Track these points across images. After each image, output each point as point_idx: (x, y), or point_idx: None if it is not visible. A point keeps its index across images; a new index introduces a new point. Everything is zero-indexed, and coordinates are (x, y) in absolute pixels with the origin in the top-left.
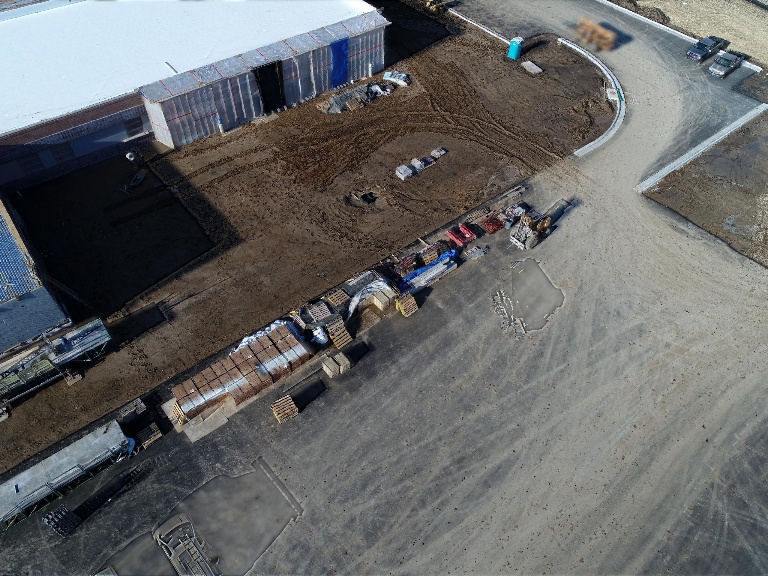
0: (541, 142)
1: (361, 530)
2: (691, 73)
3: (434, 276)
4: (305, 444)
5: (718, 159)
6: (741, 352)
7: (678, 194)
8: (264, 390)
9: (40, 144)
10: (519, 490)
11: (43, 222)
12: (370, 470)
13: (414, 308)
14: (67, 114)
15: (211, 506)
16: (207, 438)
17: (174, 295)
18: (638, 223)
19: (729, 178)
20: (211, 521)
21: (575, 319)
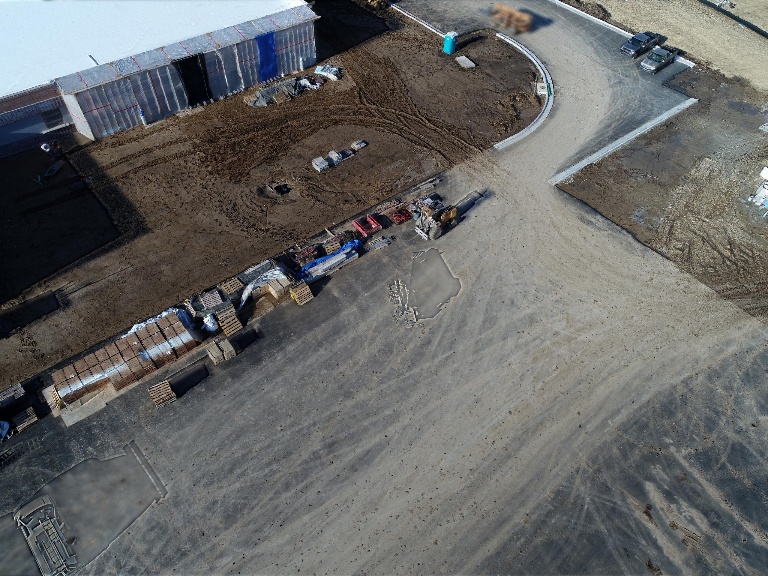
0: (463, 135)
1: (221, 512)
2: (624, 68)
3: (332, 265)
4: (179, 428)
5: (637, 152)
6: (628, 341)
7: (591, 186)
8: (147, 376)
9: None
10: (385, 474)
11: None
12: (240, 454)
13: (309, 297)
14: None
15: (76, 488)
16: (83, 422)
17: (72, 283)
18: (547, 215)
19: (645, 171)
20: (74, 503)
21: (468, 308)
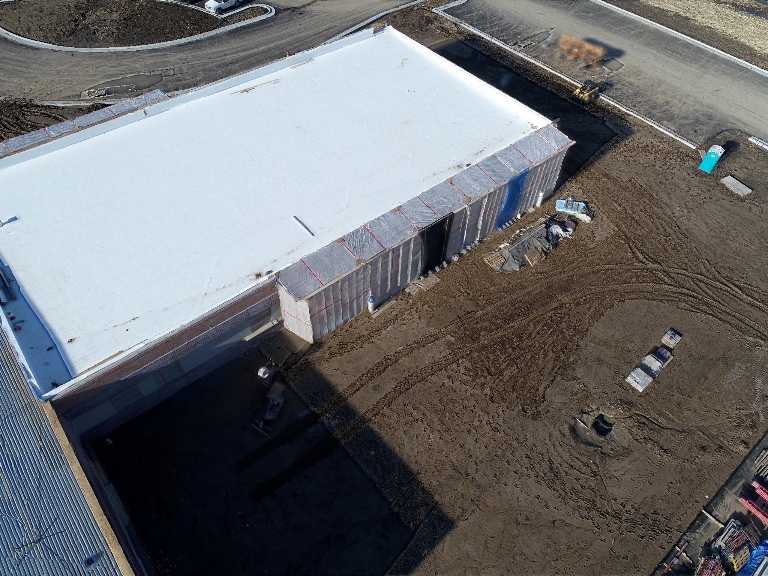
0: None
1: None
2: None
3: None
4: None
5: None
6: None
7: None
8: None
9: (141, 373)
10: None
11: (151, 496)
12: None
13: None
14: (181, 328)
15: None
16: None
17: None
18: None
19: None
20: None
21: None
